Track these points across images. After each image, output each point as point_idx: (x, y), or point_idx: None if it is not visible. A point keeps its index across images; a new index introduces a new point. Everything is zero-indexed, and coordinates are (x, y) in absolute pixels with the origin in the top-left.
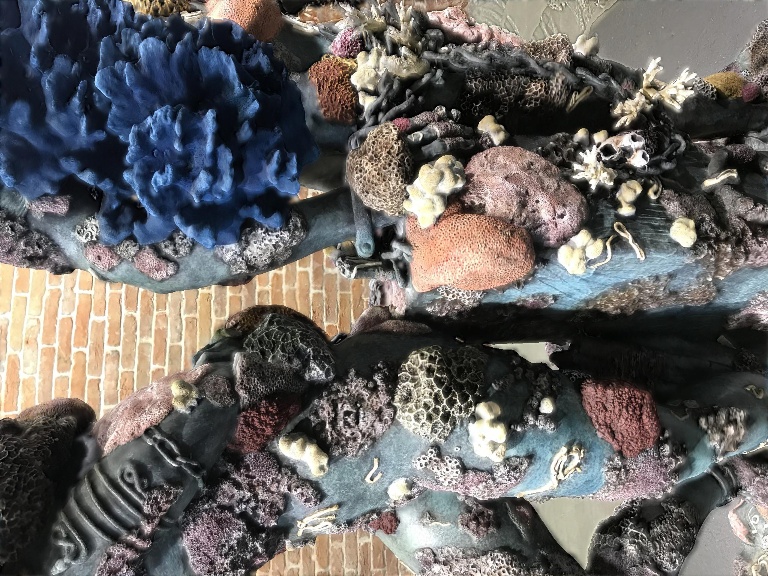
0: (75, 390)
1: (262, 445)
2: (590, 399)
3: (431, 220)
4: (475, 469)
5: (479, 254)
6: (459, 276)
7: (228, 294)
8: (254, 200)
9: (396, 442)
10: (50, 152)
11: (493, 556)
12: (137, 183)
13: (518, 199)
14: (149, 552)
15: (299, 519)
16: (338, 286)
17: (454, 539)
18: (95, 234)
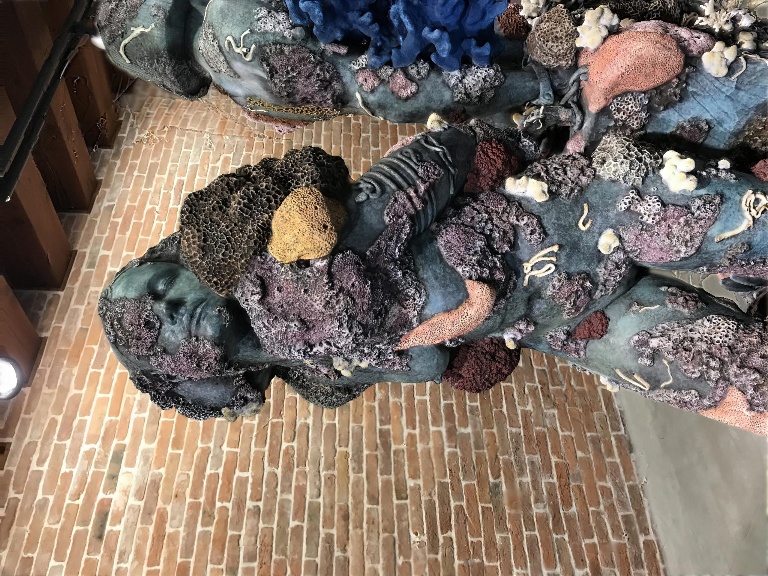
0: (216, 545)
1: (493, 181)
2: (762, 169)
3: (599, 39)
4: (674, 205)
5: (641, 42)
6: (629, 61)
7: (364, 452)
8: (471, 36)
9: (600, 191)
10: (341, 12)
11: (708, 318)
12: (402, 6)
13: (661, 28)
14: (413, 243)
15: (525, 261)
16: (472, 445)
17: (666, 316)
18: (365, 63)
